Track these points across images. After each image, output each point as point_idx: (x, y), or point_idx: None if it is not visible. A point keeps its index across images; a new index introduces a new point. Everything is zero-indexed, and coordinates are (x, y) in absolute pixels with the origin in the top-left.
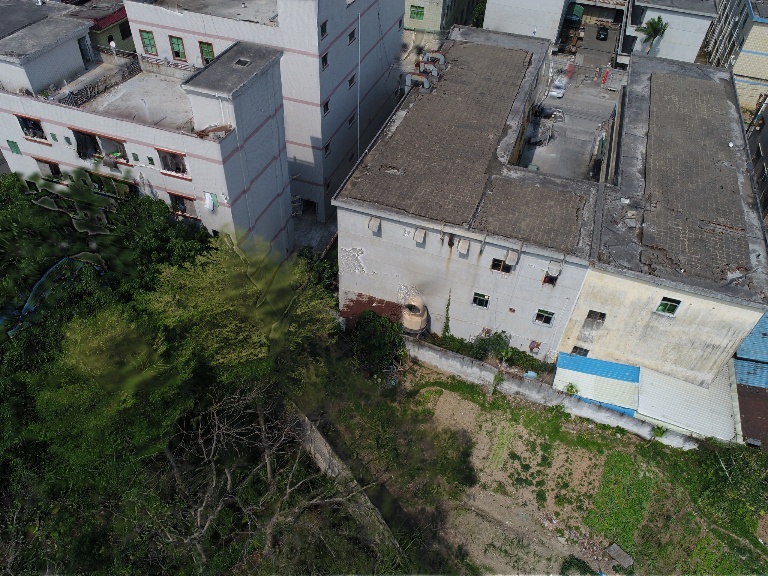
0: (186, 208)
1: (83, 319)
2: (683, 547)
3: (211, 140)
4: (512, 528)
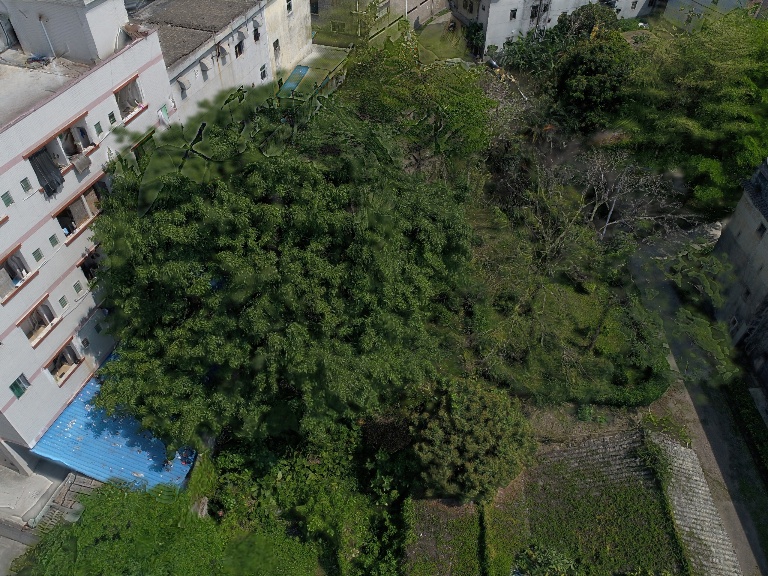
0: (148, 155)
1: (363, 124)
2: (400, 95)
3: (153, 31)
4: (392, 151)
